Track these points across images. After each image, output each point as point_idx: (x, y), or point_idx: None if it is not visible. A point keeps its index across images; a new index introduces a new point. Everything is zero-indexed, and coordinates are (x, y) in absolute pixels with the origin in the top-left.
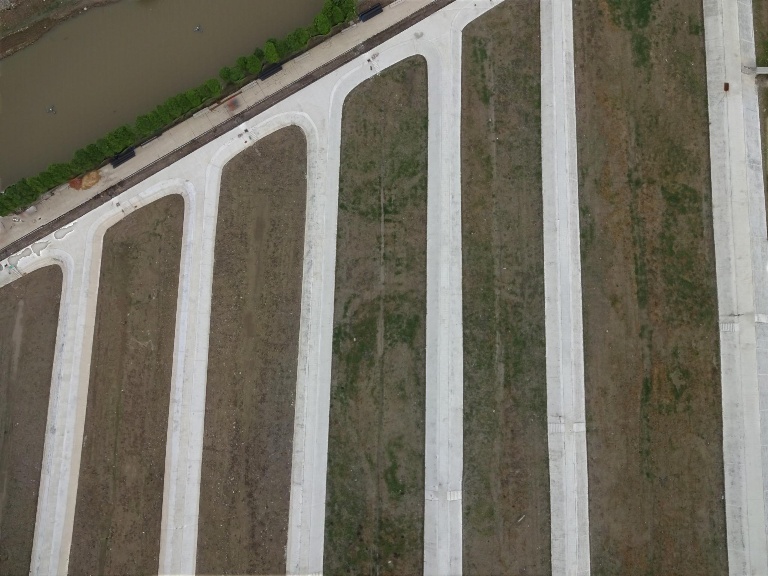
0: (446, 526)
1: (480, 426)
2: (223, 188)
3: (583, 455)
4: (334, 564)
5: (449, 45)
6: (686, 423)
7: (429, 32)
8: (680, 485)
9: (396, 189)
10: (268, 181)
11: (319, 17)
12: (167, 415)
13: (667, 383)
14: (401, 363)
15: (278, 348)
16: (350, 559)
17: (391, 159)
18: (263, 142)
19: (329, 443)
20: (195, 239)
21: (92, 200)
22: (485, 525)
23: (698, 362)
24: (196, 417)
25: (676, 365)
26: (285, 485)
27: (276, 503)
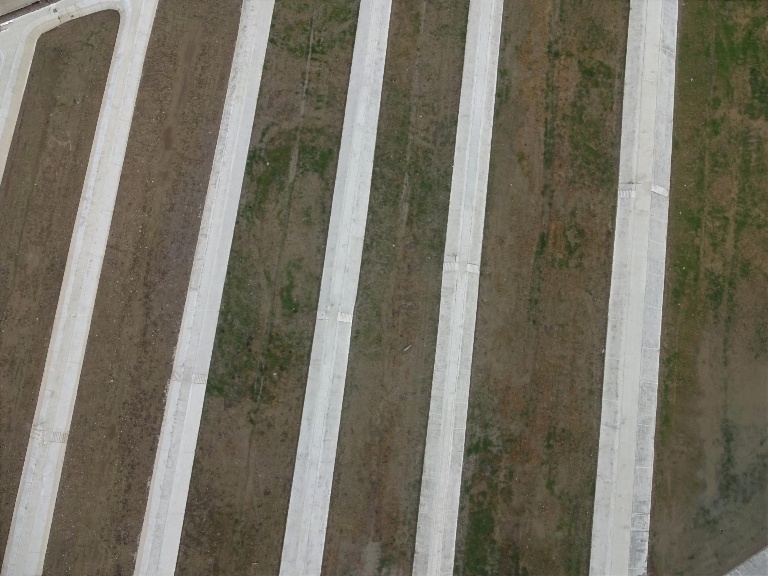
0: (333, 344)
1: (378, 257)
2: (159, 10)
3: (474, 295)
4: (220, 370)
5: None
6: (576, 278)
7: None
8: (564, 335)
9: (326, 32)
10: (204, 9)
11: None
12: (76, 212)
13: (562, 239)
14: (310, 191)
15: (193, 163)
16: (236, 367)
17: (324, 4)
18: None
19: (230, 256)
20: (125, 51)
21: (31, 5)
22: (372, 350)
23: (594, 224)
24: (104, 216)
25: (573, 224)
26: (182, 290)
27: (171, 306)
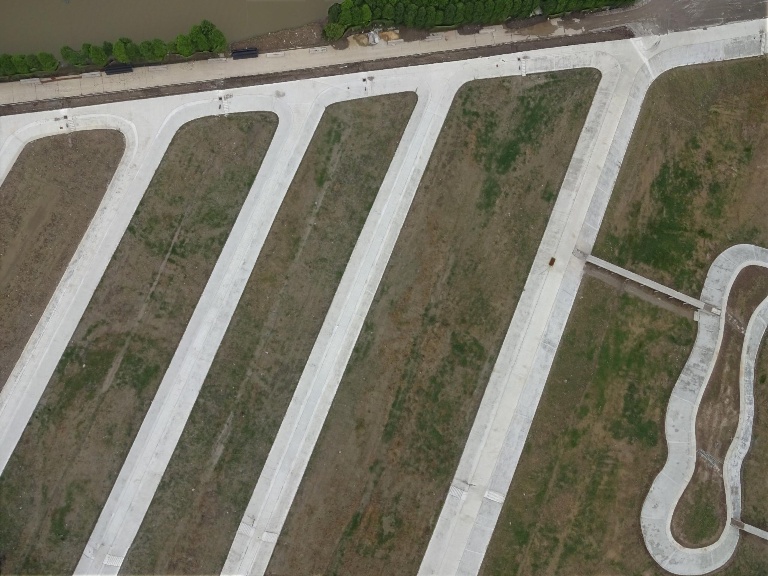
0: None
1: (172, 500)
2: (18, 164)
3: (262, 566)
4: None
5: (306, 116)
6: (378, 571)
7: (291, 95)
8: None
9: (193, 233)
10: (68, 175)
11: (179, 38)
12: None
13: (376, 525)
14: (121, 407)
15: (1, 345)
16: None
17: (202, 202)
18: (80, 135)
19: (10, 460)
20: None
21: None
22: None
23: (415, 515)
24: None
25: (393, 510)
26: None
27: None
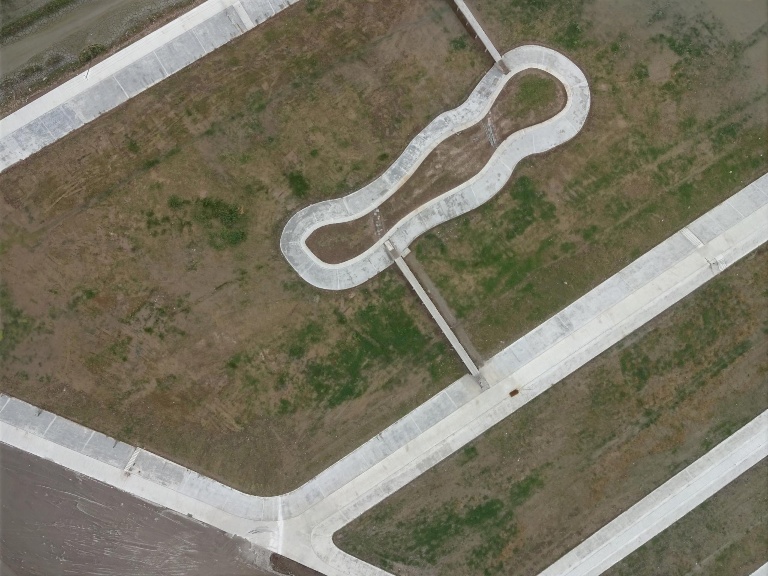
0: None
1: None
2: None
3: None
4: None
5: None
6: None
7: None
8: None
9: None
10: None
11: None
12: None
13: None
14: None
15: None
16: None
17: None
18: None
19: None
20: None
21: None
22: None
23: (762, 270)
24: None
25: None
26: None
27: None
